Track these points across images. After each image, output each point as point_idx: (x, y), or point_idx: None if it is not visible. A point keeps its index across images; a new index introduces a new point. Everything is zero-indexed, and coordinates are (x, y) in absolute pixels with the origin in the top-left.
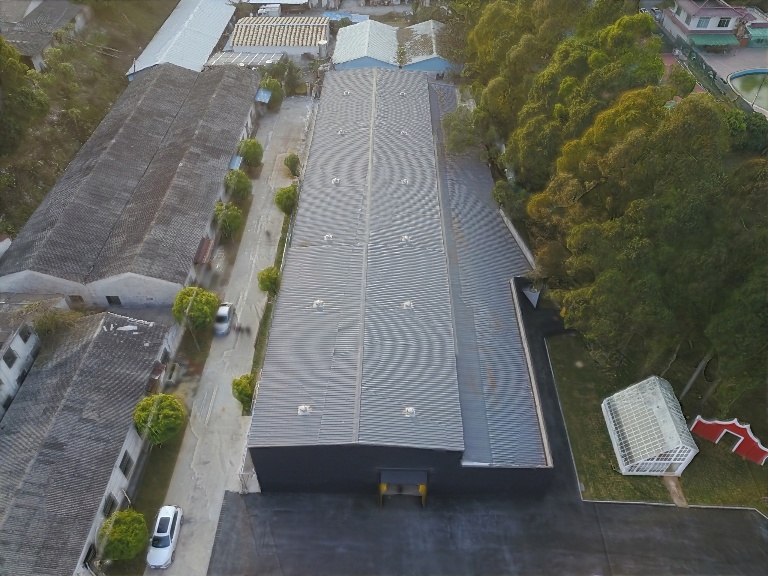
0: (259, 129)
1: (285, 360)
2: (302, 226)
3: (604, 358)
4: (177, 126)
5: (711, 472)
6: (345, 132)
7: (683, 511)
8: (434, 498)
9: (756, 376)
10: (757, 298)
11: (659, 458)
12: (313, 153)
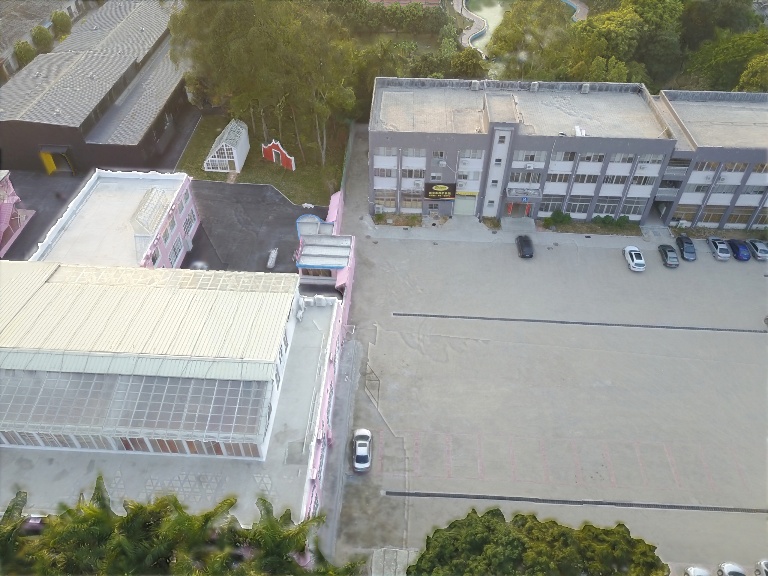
0: (85, 15)
1: (3, 95)
2: (59, 48)
3: (194, 101)
4: (14, 4)
5: (260, 172)
6: (122, 5)
7: (228, 184)
8: (82, 173)
9: (227, 81)
10: (210, 29)
11: (218, 156)
12: (93, 16)
